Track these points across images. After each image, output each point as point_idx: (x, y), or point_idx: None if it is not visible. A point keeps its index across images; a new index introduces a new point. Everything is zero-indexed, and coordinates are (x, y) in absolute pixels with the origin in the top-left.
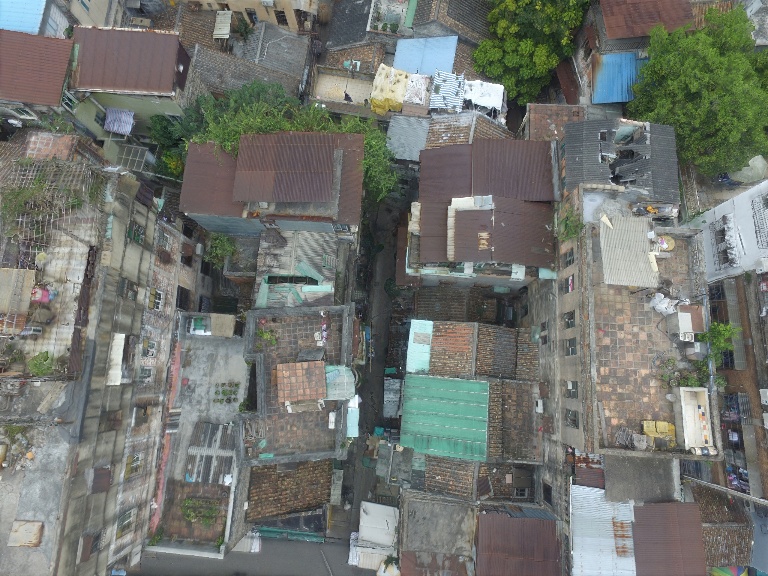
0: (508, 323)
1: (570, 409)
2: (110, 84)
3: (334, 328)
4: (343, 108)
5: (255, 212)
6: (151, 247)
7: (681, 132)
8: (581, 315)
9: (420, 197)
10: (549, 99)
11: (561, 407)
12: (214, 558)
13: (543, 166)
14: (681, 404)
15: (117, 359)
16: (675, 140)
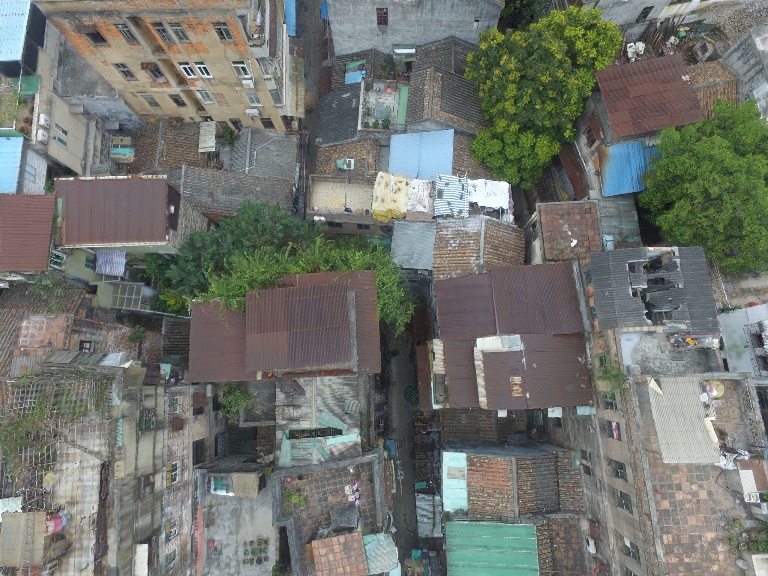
0: (539, 428)
1: (631, 571)
2: (99, 238)
3: (364, 478)
4: (343, 217)
5: (270, 371)
6: (163, 423)
7: (704, 234)
8: (635, 477)
9: (441, 334)
10: (551, 176)
11: (619, 561)
12: None
13: (568, 292)
14: (755, 575)
15: (142, 574)
16: None
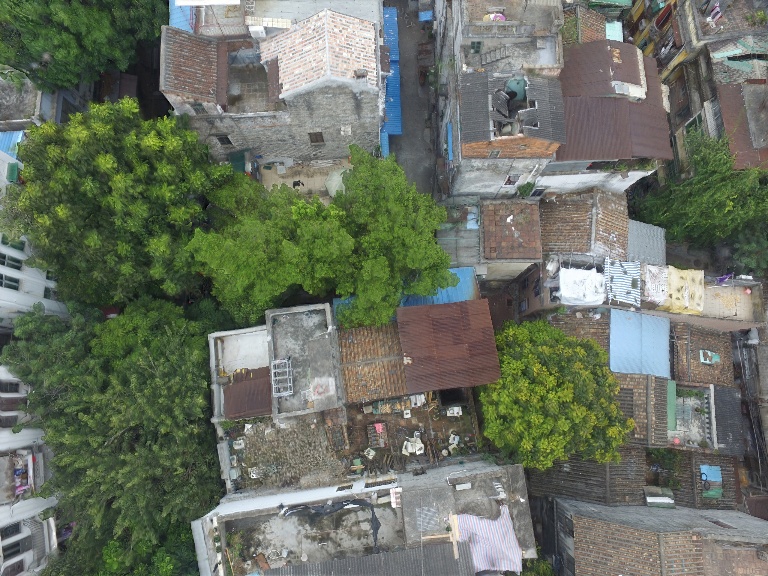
0: None
1: None
2: None
3: None
4: None
5: None
6: None
7: None
8: None
9: None
10: None
11: None
12: None
13: None
14: None
15: None
16: (463, 131)
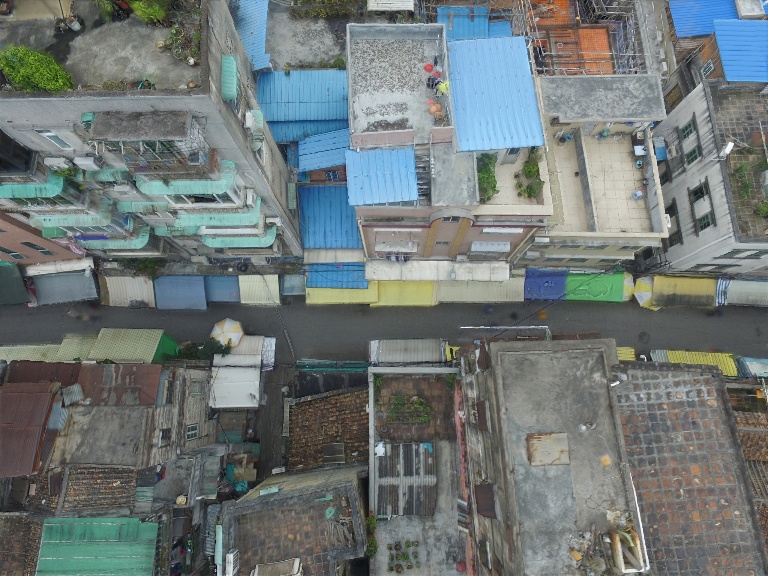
0: None
1: None
2: None
3: None
4: None
5: None
6: None
7: None
8: None
9: None
10: None
11: None
12: (425, 323)
13: None
14: None
15: None
16: None
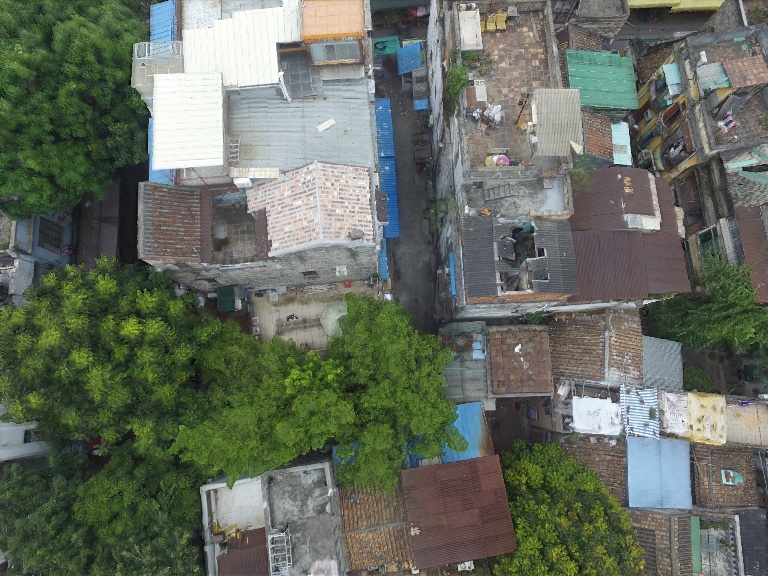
0: None
1: None
2: None
3: None
4: None
5: None
6: None
7: None
8: None
9: None
10: None
11: None
12: None
13: None
14: None
15: None
16: (467, 283)
